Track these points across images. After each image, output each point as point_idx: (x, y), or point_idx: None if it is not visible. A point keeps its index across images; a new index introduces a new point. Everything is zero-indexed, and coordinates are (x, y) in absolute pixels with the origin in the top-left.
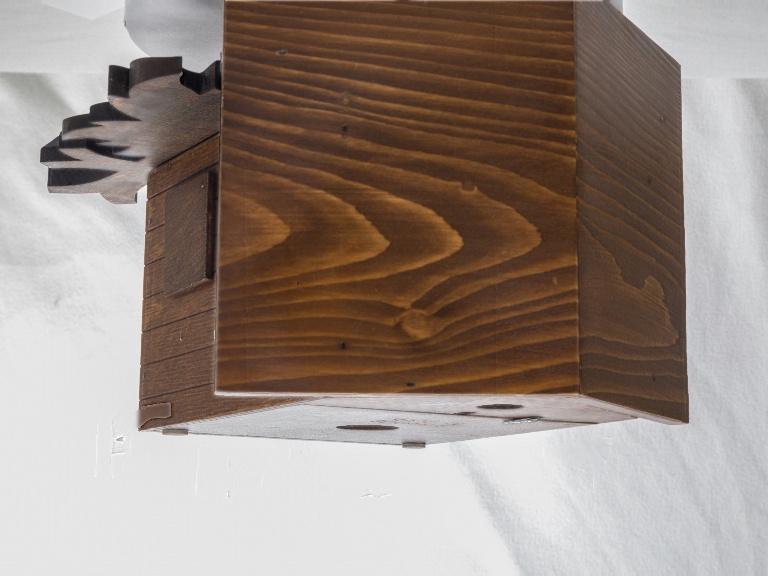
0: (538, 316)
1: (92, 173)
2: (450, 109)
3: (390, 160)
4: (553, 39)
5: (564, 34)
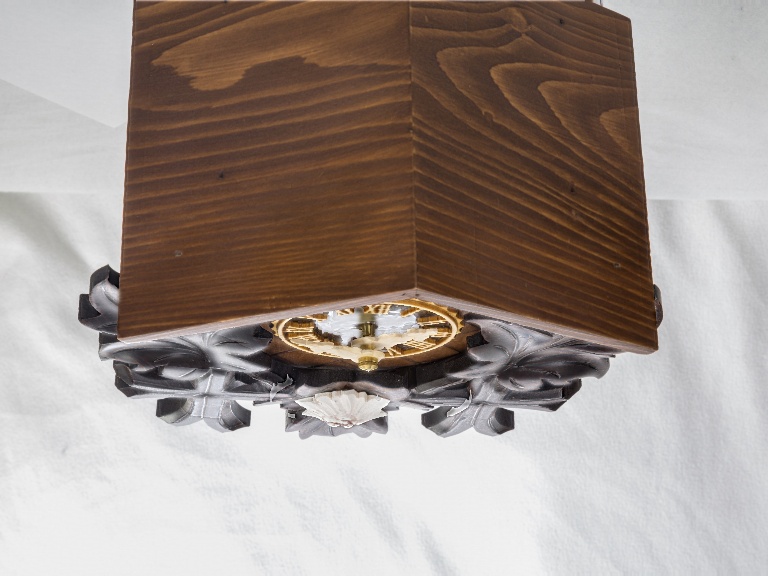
0: None
1: None
2: (504, 185)
3: (542, 155)
4: (432, 228)
5: (423, 230)
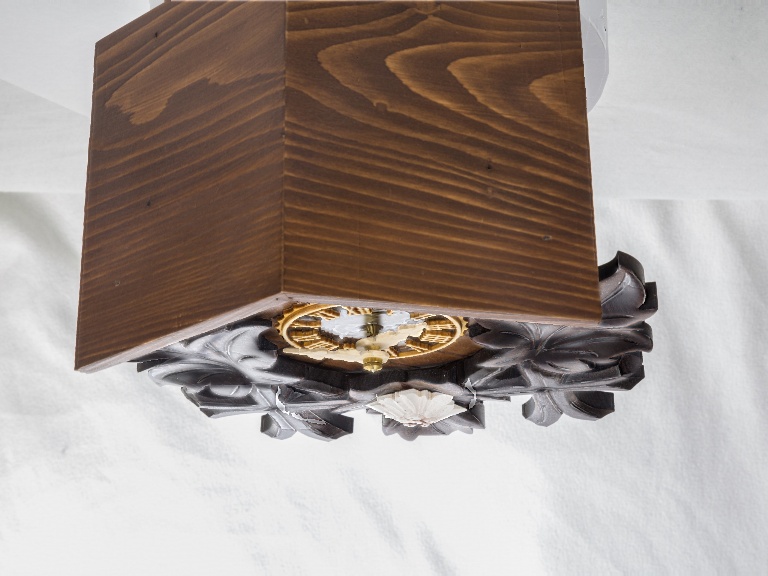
0: None
1: (583, 392)
2: (399, 174)
3: (450, 136)
4: (304, 229)
5: (293, 233)
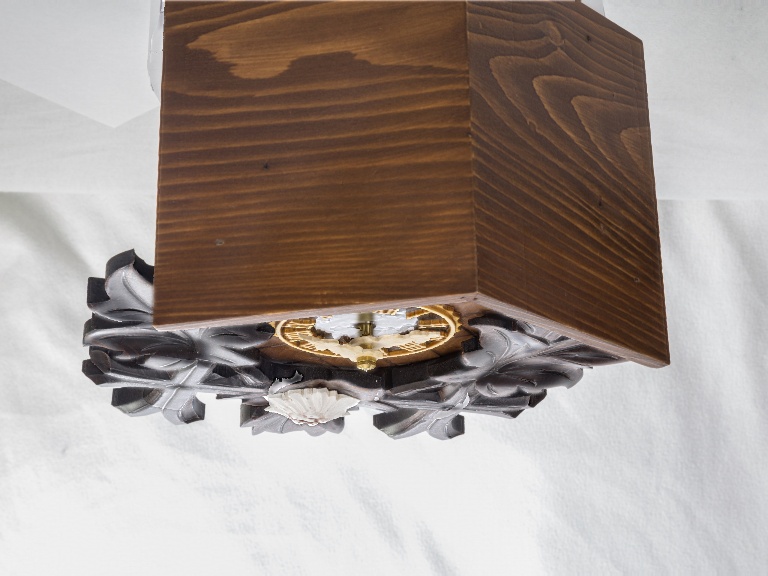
0: (489, 3)
1: None
2: (546, 195)
3: (576, 167)
4: (489, 233)
5: (482, 235)
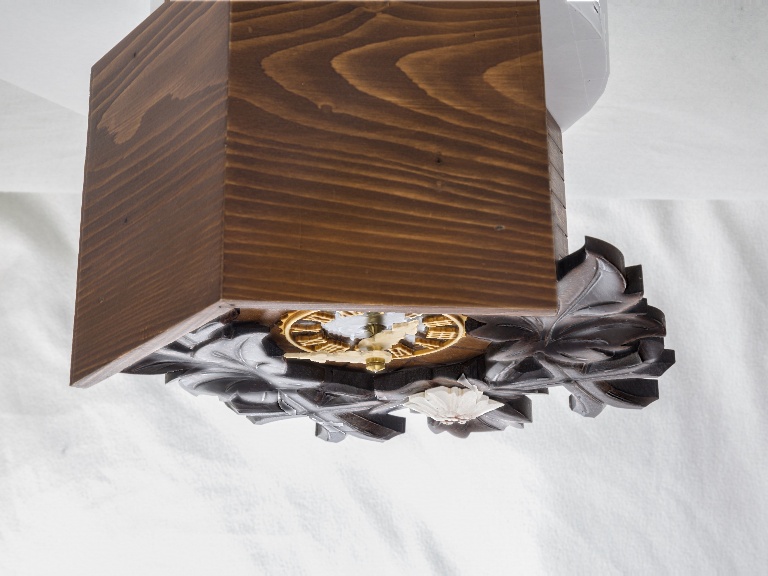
0: (266, 3)
1: (620, 380)
2: (343, 175)
3: (397, 132)
4: (244, 236)
5: (234, 240)
